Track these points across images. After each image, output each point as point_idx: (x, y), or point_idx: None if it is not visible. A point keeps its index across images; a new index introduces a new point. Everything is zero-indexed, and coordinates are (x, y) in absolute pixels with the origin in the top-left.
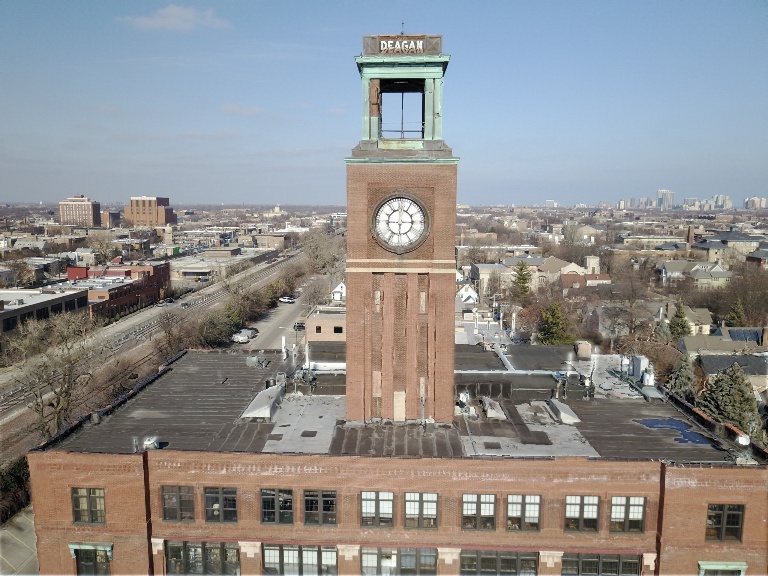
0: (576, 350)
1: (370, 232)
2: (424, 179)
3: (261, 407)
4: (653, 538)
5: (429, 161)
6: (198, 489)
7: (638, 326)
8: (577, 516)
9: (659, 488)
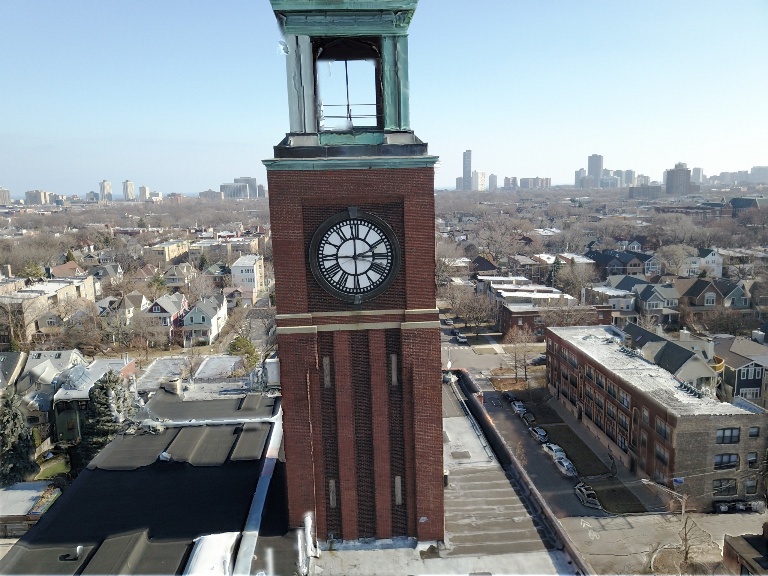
0: (172, 391)
1: None
2: None
3: None
4: None
5: None
6: None
7: None
8: None
9: None
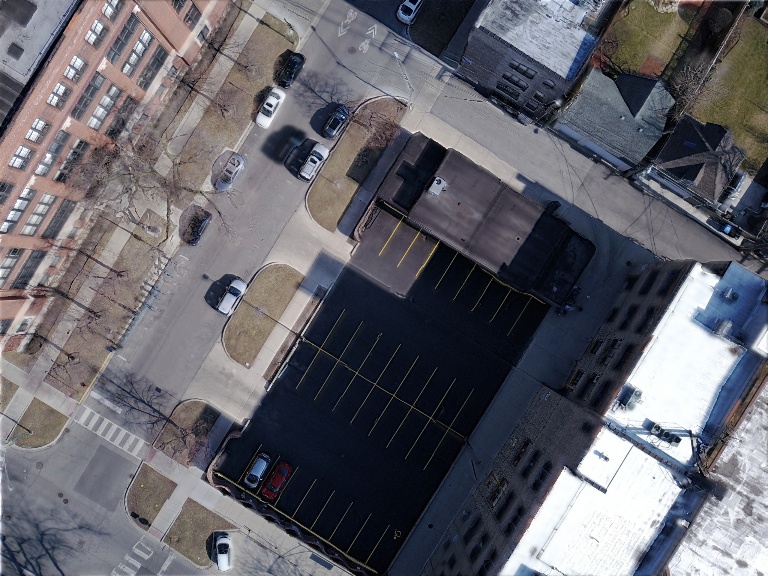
0: None
1: None
2: None
3: None
4: (130, 0)
5: None
6: None
7: None
8: (95, 38)
9: None
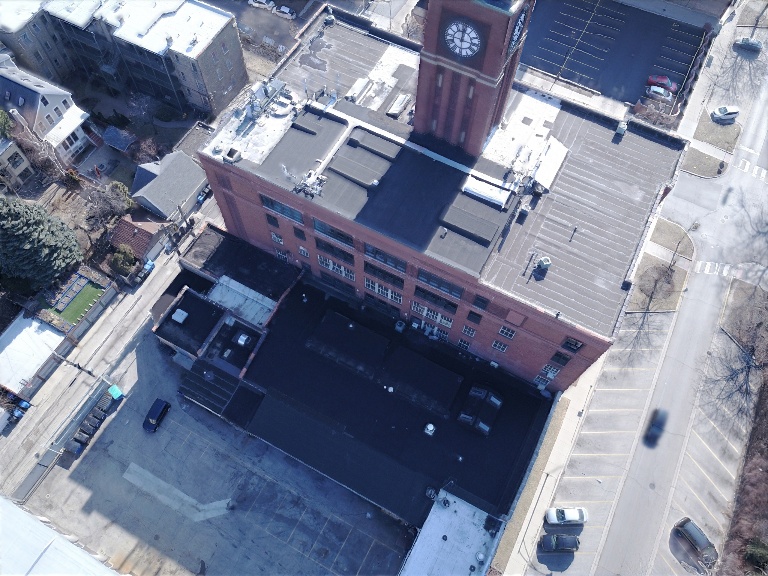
0: None
1: None
2: None
3: (555, 146)
4: None
5: None
6: None
7: None
8: None
9: None
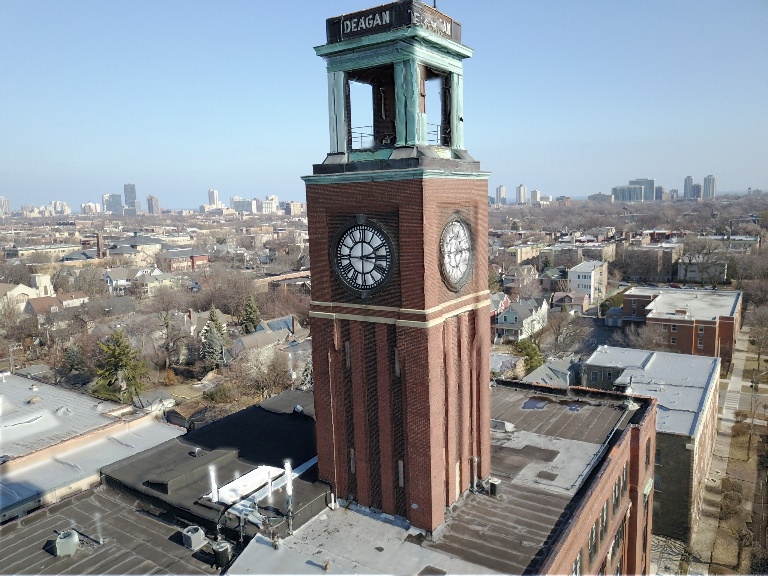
0: None
1: (438, 269)
2: (465, 197)
3: None
4: (628, 491)
5: (468, 175)
6: None
7: (182, 338)
8: (613, 502)
9: (630, 449)
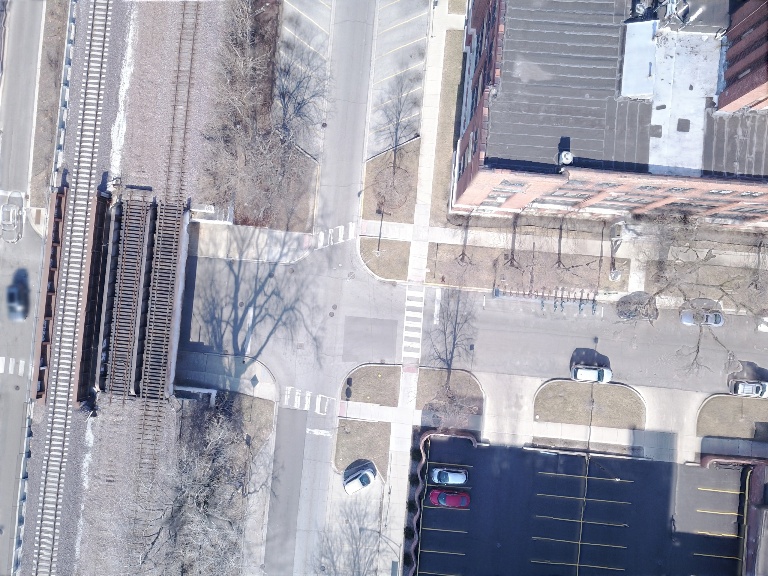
0: None
1: None
2: None
3: (642, 85)
4: None
5: None
6: (597, 182)
7: None
8: None
9: None
